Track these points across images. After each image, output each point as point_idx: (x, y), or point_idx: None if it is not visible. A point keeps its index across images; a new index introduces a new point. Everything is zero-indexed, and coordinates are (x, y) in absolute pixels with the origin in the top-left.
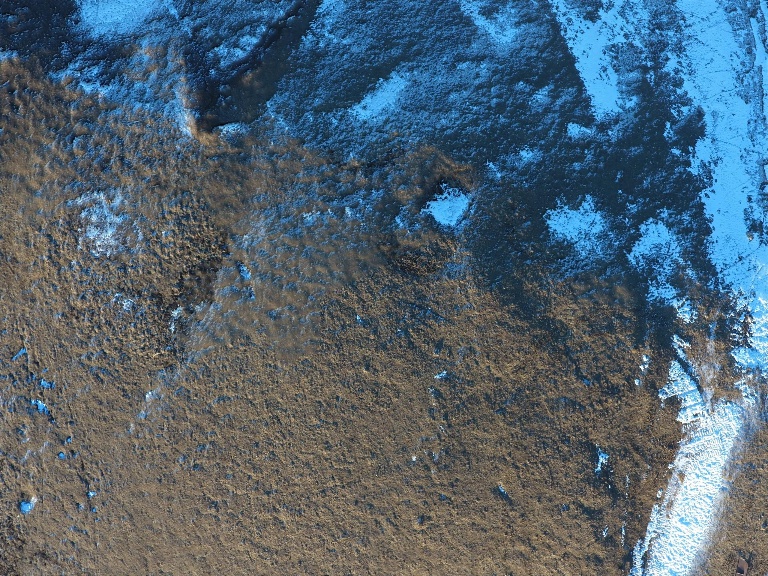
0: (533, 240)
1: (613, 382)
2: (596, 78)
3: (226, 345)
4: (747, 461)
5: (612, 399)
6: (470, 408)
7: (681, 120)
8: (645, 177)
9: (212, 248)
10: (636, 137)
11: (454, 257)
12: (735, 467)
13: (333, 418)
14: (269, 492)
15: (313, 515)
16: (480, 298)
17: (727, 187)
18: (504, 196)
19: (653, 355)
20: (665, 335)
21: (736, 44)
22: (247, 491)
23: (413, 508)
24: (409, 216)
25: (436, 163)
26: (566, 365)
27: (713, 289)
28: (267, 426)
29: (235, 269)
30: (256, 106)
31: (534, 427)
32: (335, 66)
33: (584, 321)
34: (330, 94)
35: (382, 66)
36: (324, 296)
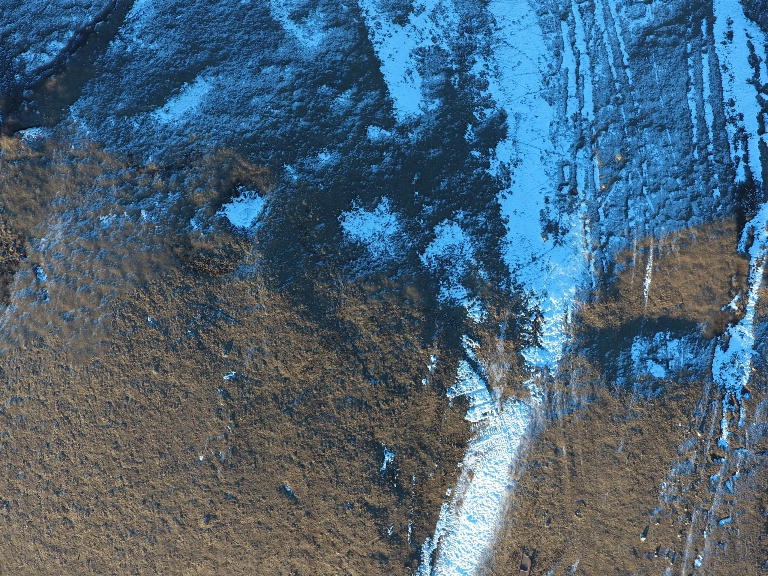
0: (326, 242)
1: (400, 382)
2: (400, 81)
3: (20, 347)
4: (532, 459)
5: (398, 398)
6: (257, 408)
7: (483, 122)
8: (442, 179)
9: (10, 251)
10: (436, 139)
11: (246, 259)
12: (521, 465)
13: (122, 419)
14: (59, 492)
15: (101, 515)
16: (270, 299)
17: (525, 188)
18: (299, 198)
19: (441, 355)
20: (454, 335)
21: (545, 47)
22: (37, 491)
23: (199, 507)
24: (204, 218)
25: (233, 166)
26: (353, 365)
27: (504, 289)
28: (58, 427)
29: (31, 272)
30: (59, 111)
31: (320, 426)
32: (140, 71)
33: (373, 321)
34: (133, 98)
35: (187, 70)
36: (116, 298)
